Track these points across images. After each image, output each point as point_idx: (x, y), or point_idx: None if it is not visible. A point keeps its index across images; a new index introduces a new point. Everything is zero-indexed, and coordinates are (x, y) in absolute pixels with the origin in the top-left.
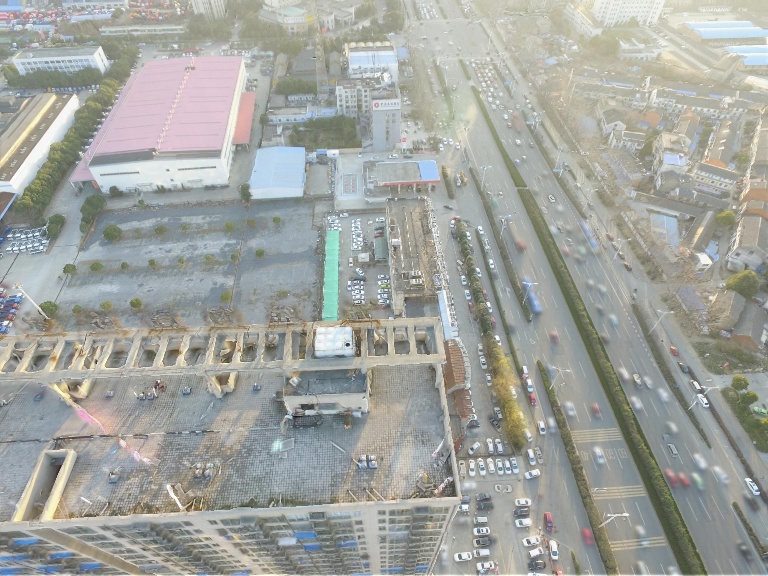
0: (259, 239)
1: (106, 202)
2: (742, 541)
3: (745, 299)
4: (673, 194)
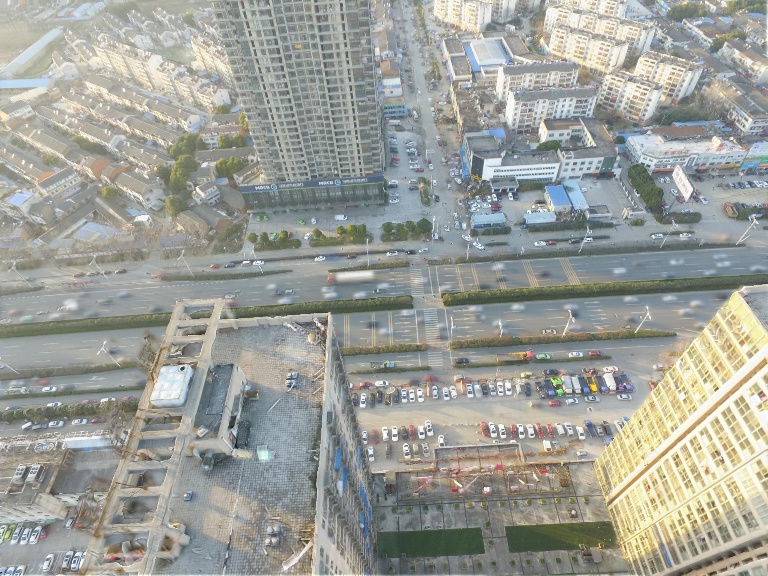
0: None
1: None
2: (350, 276)
3: (189, 210)
4: (60, 214)
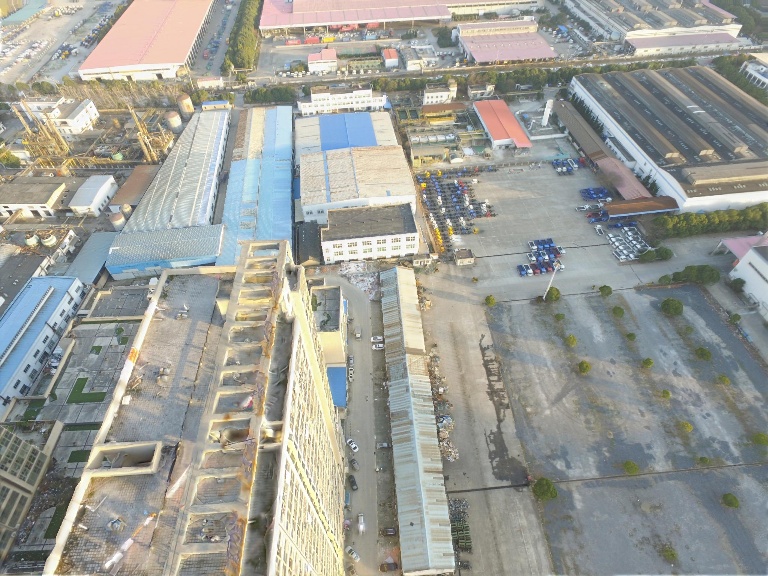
0: (761, 491)
1: (715, 283)
2: None
3: None
4: None
